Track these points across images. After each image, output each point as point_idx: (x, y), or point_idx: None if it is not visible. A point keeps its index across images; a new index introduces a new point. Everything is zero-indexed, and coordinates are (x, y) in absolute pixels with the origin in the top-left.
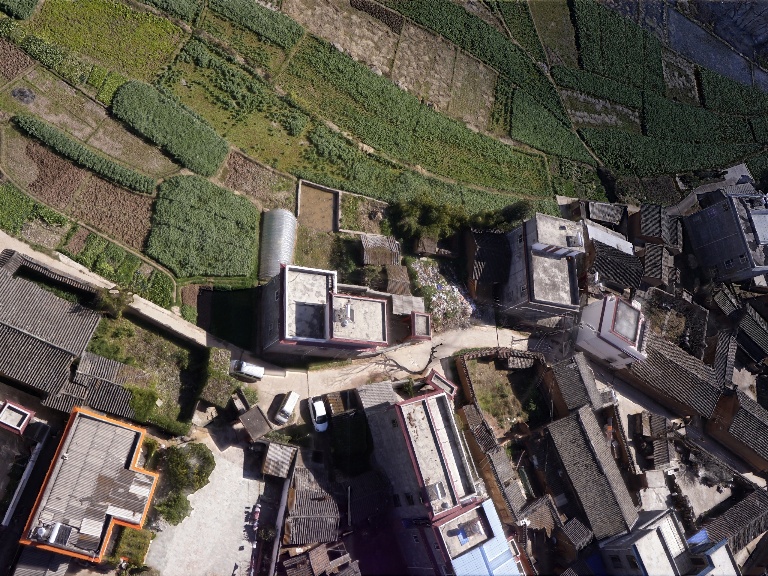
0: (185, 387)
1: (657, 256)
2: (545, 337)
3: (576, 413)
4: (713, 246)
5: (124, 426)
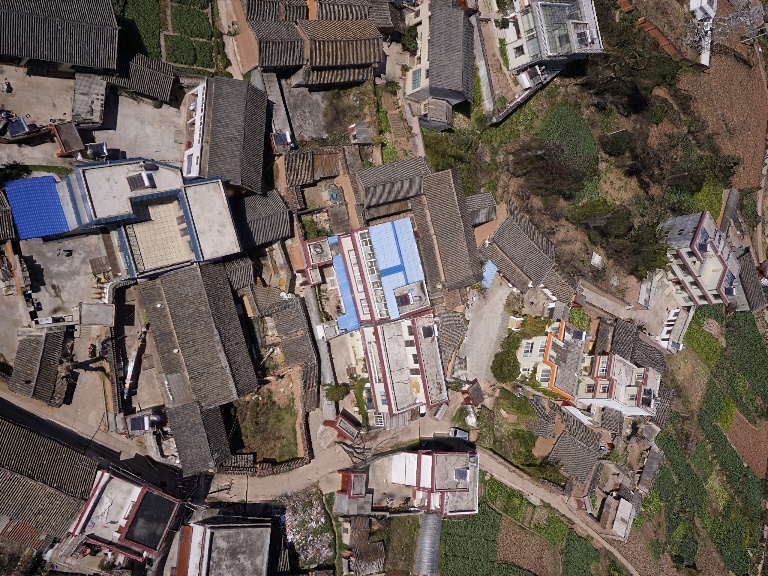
0: None
1: None
2: None
3: None
4: None
5: None
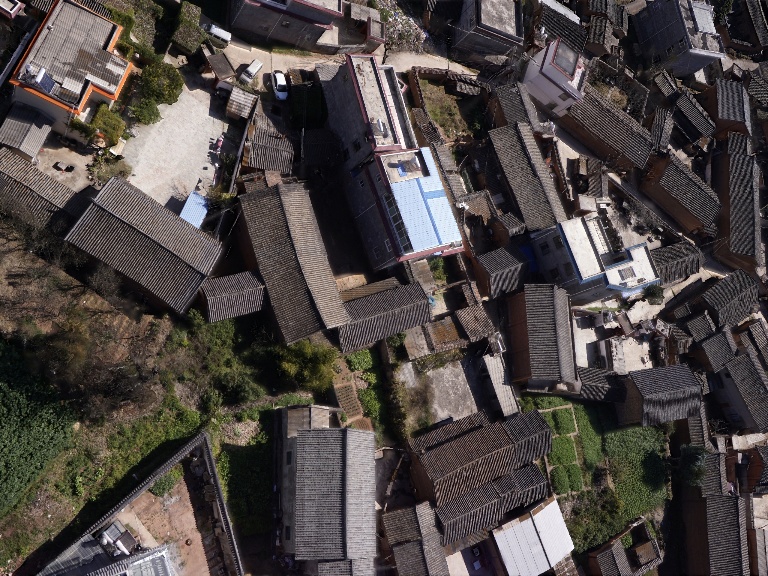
0: (159, 33)
1: (601, 26)
2: (493, 78)
3: (515, 122)
4: (657, 37)
5: (103, 18)
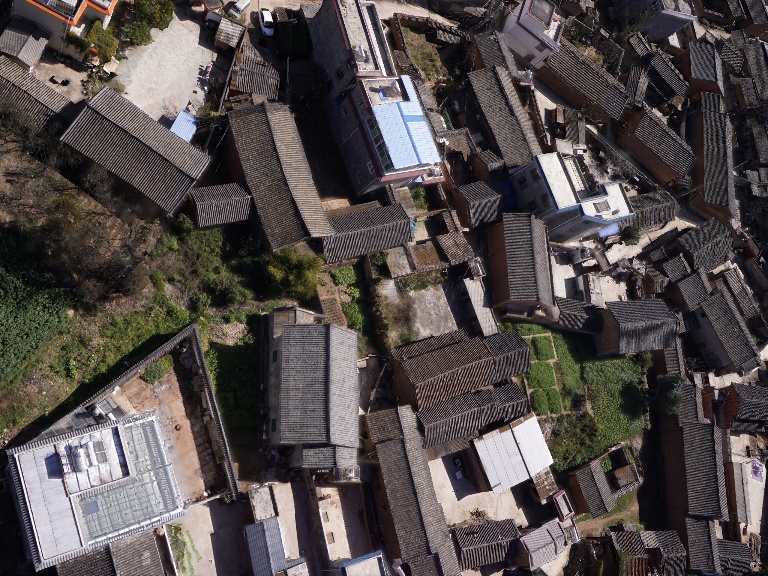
0: None
1: None
2: (473, 30)
3: (493, 65)
4: (631, 1)
5: None
